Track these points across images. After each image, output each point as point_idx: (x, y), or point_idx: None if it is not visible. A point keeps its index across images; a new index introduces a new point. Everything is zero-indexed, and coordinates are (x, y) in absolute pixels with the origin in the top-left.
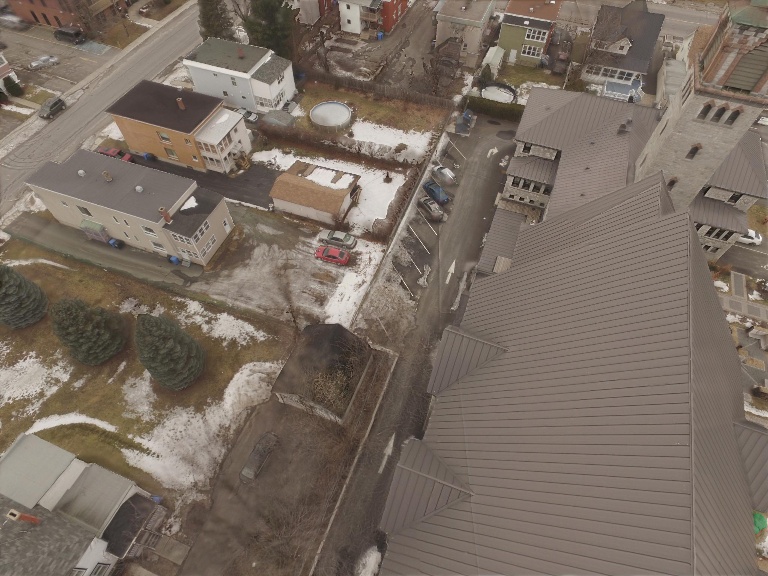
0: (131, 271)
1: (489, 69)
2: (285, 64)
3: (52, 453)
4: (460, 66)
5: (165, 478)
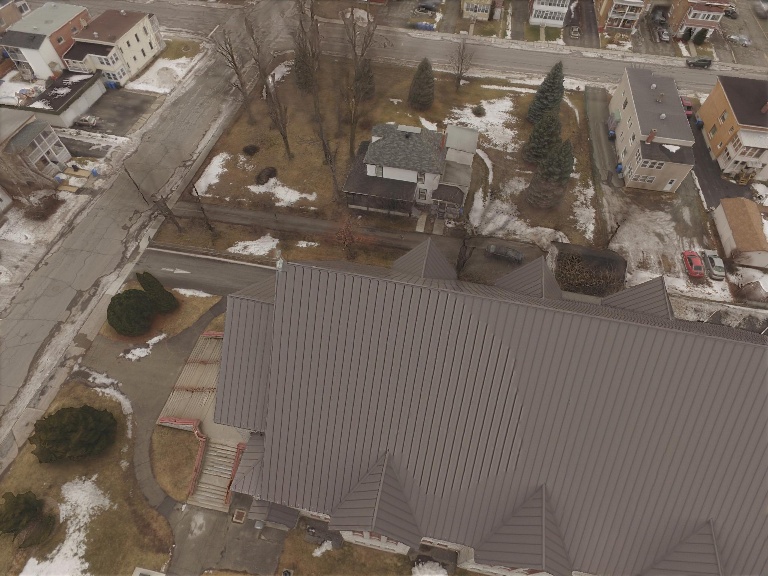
0: (596, 151)
1: None
2: None
3: (473, 144)
4: None
5: (474, 213)
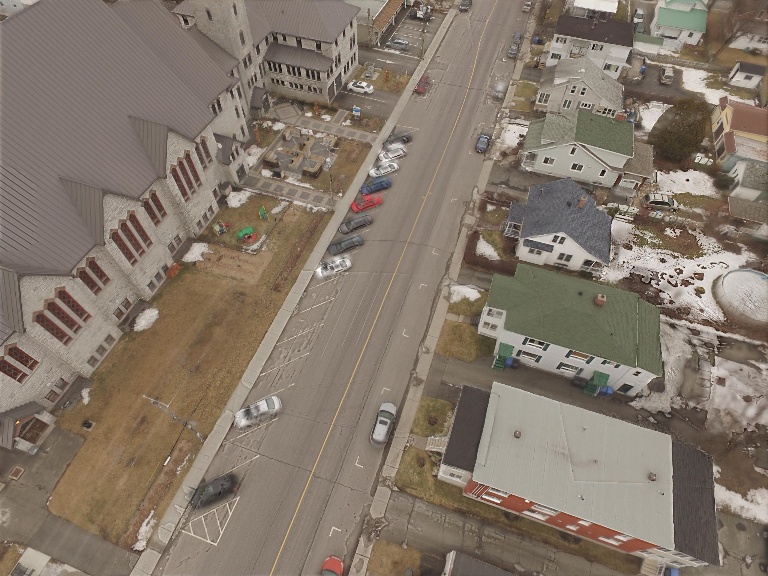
0: None
1: None
2: None
3: None
4: None
5: None
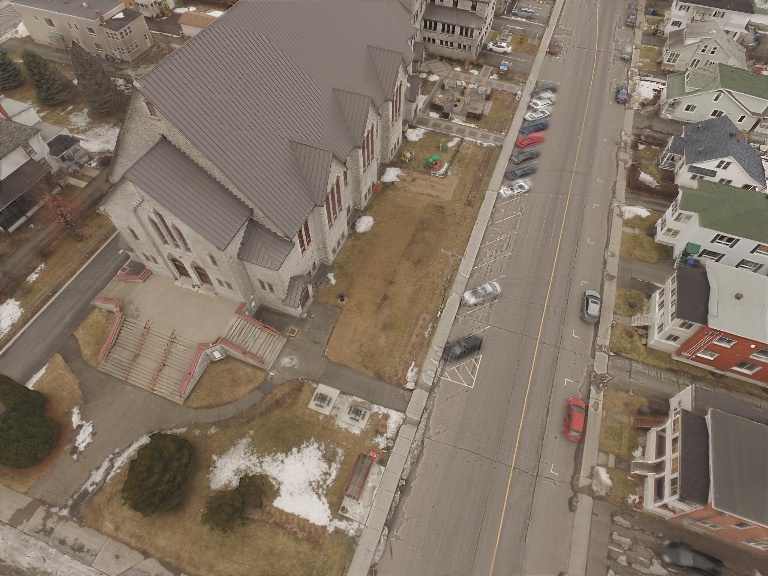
0: None
1: None
2: None
3: (19, 104)
4: None
5: (90, 148)
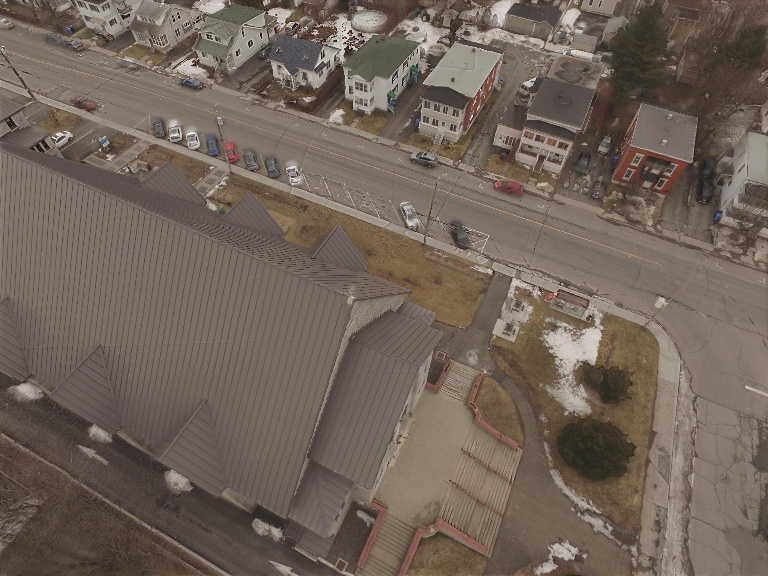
0: None
1: None
2: None
3: None
4: None
5: None
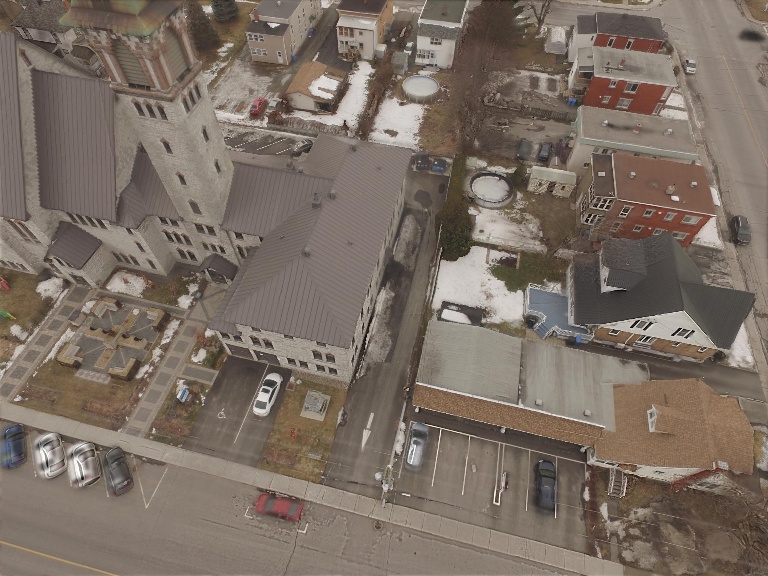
0: None
1: (520, 169)
2: (449, 36)
3: None
4: (546, 164)
5: None
